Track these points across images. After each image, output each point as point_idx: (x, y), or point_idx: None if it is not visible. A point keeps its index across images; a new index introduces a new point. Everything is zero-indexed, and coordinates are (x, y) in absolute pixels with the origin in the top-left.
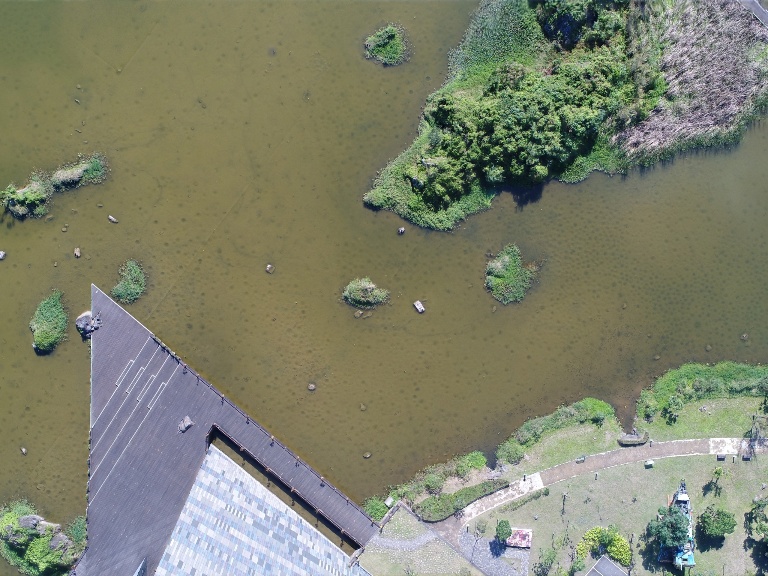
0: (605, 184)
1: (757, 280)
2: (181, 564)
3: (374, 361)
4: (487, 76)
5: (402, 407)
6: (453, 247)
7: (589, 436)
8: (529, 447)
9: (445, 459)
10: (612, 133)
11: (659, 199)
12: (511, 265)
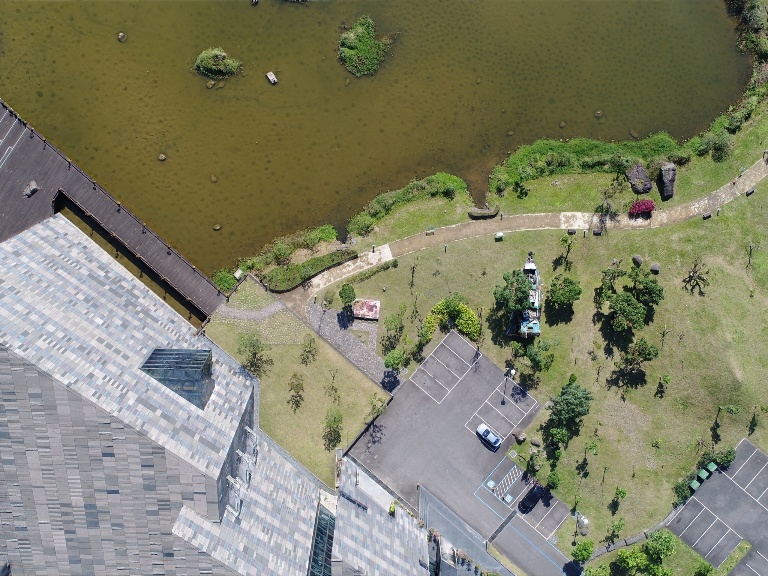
0: None
1: (612, 57)
2: None
3: (226, 132)
4: None
5: (253, 179)
6: (307, 19)
7: (440, 209)
8: (379, 219)
9: None
10: None
11: None
12: (365, 37)
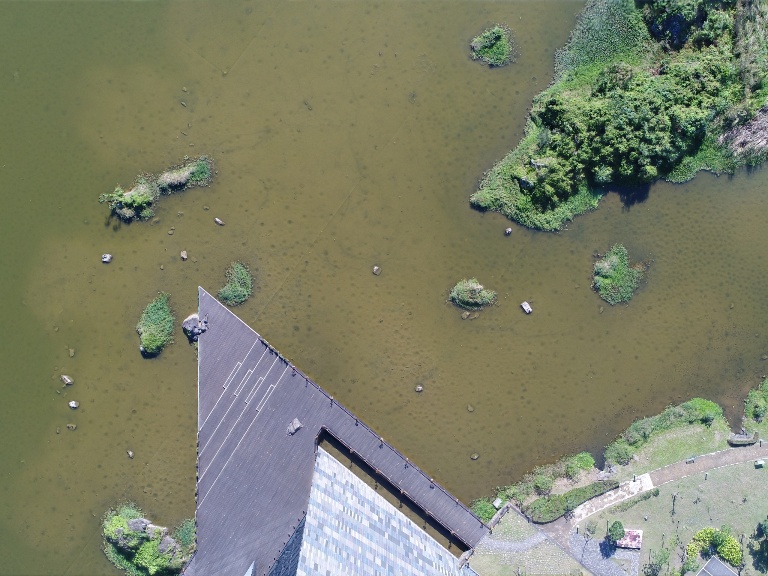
0: (712, 184)
1: None
2: (316, 566)
3: (481, 362)
4: (594, 76)
5: (509, 408)
6: (560, 248)
7: (698, 436)
8: (638, 448)
9: (553, 460)
10: (719, 133)
11: (766, 198)
12: (618, 265)
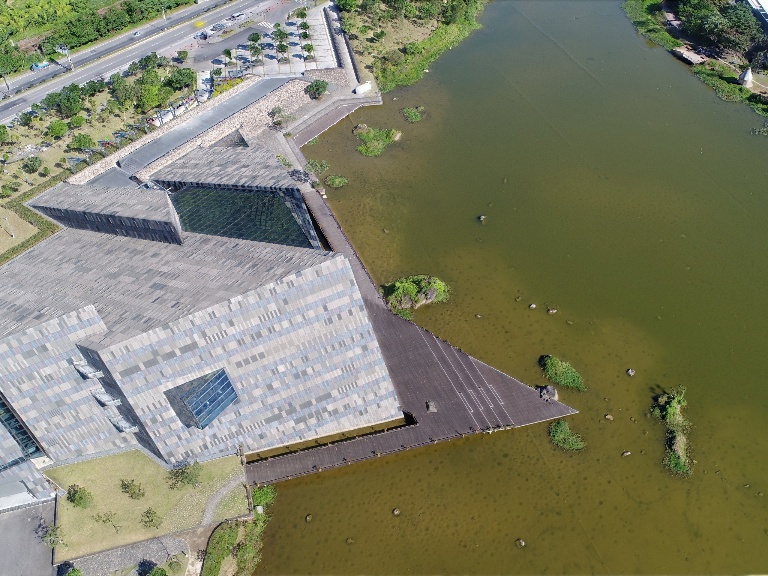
0: None
1: None
2: (351, 313)
3: None
4: None
5: (326, 573)
6: None
7: None
8: None
9: None
10: None
11: None
12: None
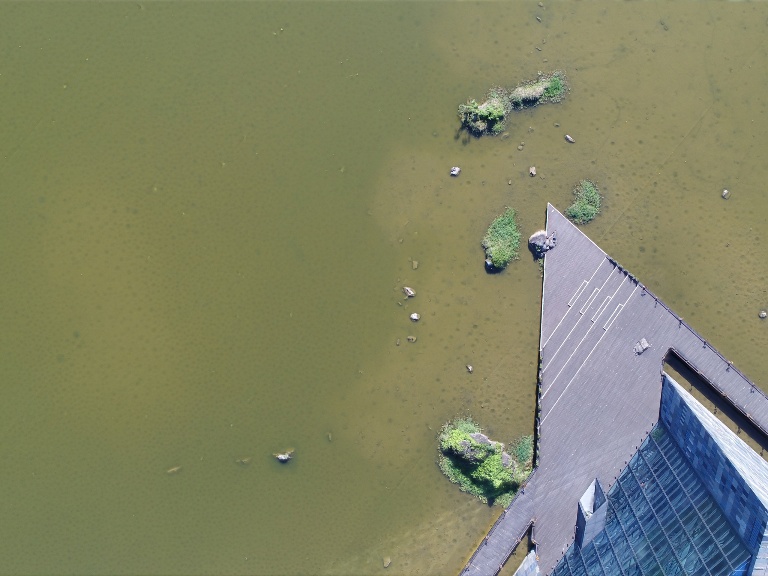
0: None
1: None
2: (742, 470)
3: None
4: None
5: None
6: None
7: None
8: None
9: None
10: None
11: None
12: None
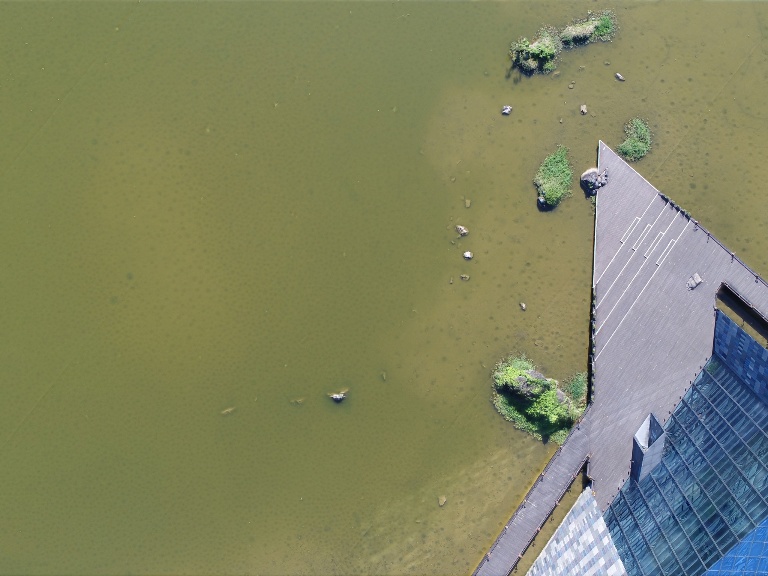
0: None
1: None
2: None
3: None
4: None
5: None
6: None
7: None
8: None
9: None
10: None
11: None
12: None
